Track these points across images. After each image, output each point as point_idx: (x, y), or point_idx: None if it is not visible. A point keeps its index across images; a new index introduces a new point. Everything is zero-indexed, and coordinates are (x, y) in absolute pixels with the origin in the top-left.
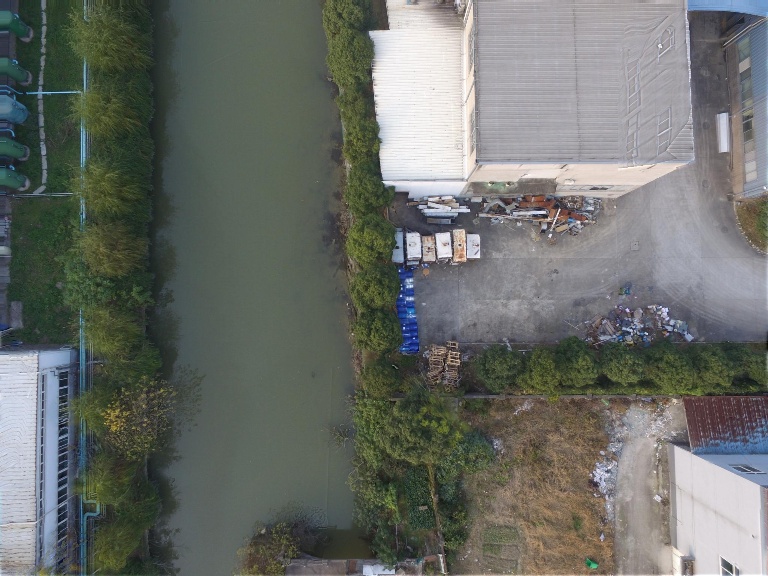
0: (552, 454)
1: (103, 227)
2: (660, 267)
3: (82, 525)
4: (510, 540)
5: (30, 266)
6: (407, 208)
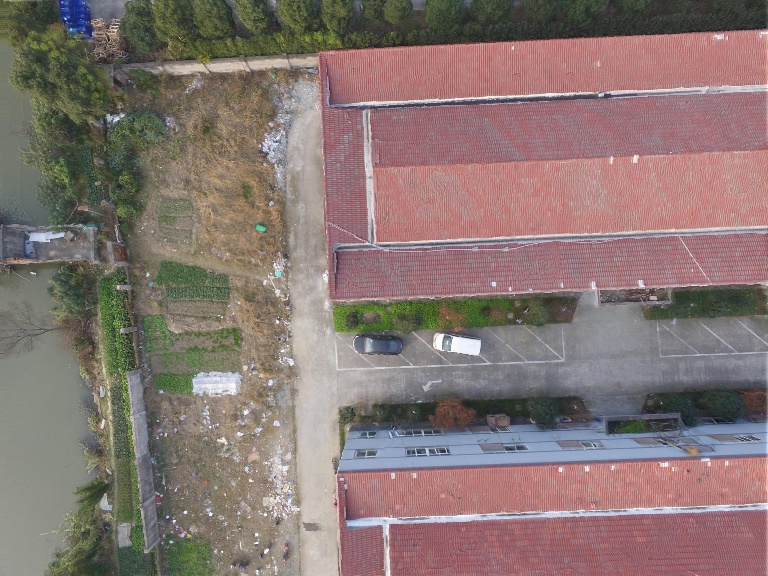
0: (222, 128)
1: None
2: None
3: None
4: (184, 211)
5: None
6: None
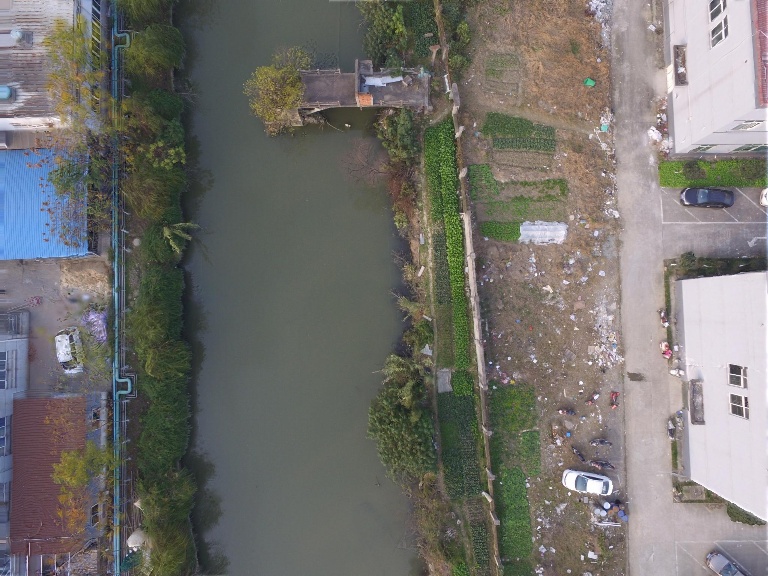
0: None
1: None
2: None
3: (113, 53)
4: (511, 65)
5: None
6: None
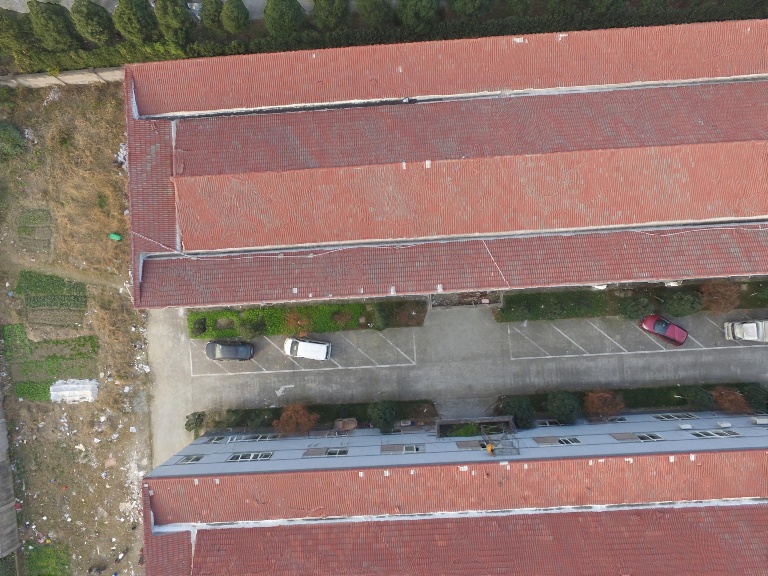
0: (79, 138)
1: None
2: None
3: None
4: (42, 221)
5: None
6: None
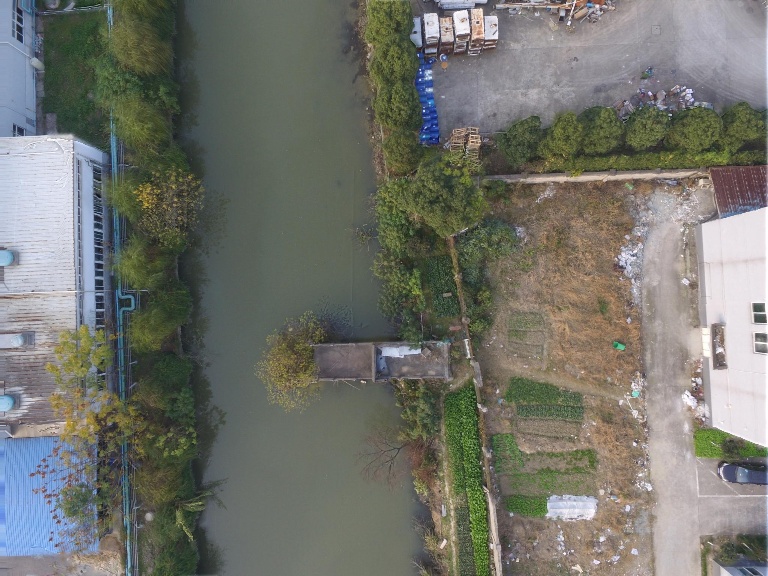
0: (576, 240)
1: (130, 23)
2: (683, 50)
3: (118, 318)
4: (535, 325)
5: (62, 76)
6: (424, 5)
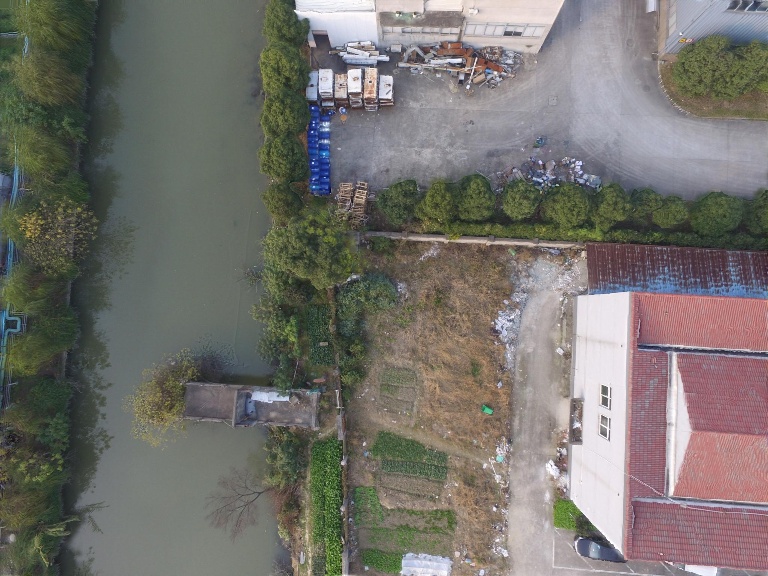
0: (455, 300)
1: (38, 55)
2: (577, 122)
3: (3, 339)
4: (407, 382)
5: None
6: (330, 57)
